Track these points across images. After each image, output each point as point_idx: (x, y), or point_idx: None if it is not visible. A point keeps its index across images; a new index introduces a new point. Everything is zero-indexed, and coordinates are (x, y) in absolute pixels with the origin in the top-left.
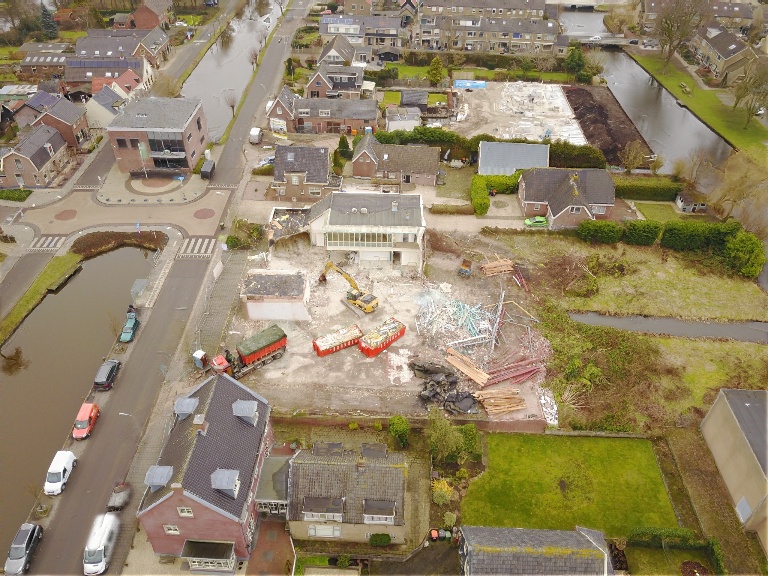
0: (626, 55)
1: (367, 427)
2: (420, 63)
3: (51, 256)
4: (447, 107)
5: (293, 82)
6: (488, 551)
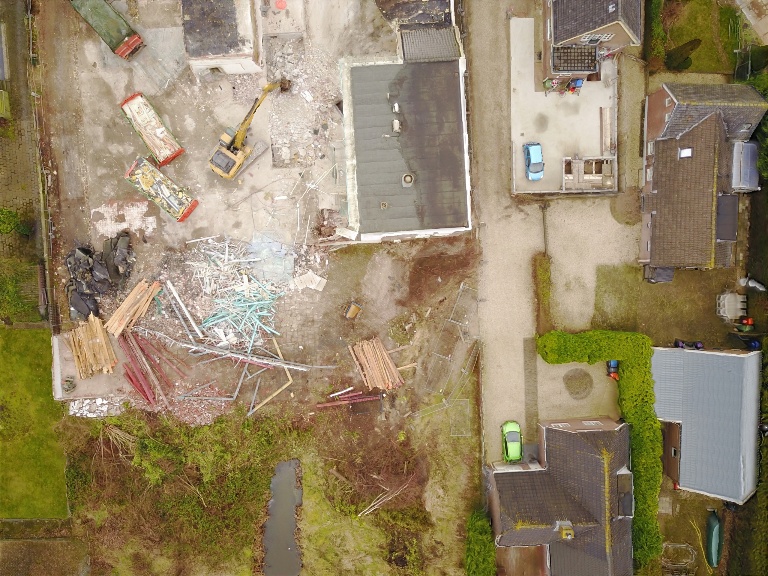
0: None
1: None
2: None
3: None
4: None
5: None
6: None
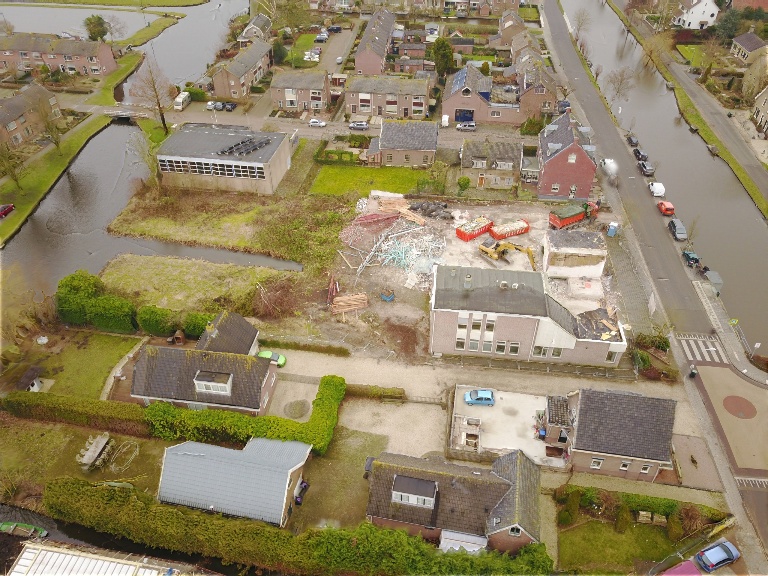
0: None
1: None
2: None
3: None
4: None
5: None
6: None
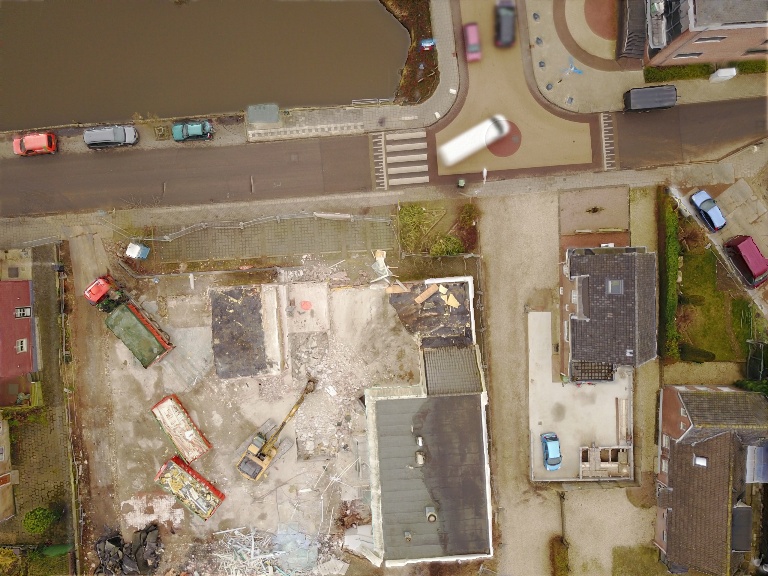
0: None
1: None
2: None
3: None
4: None
5: None
6: None
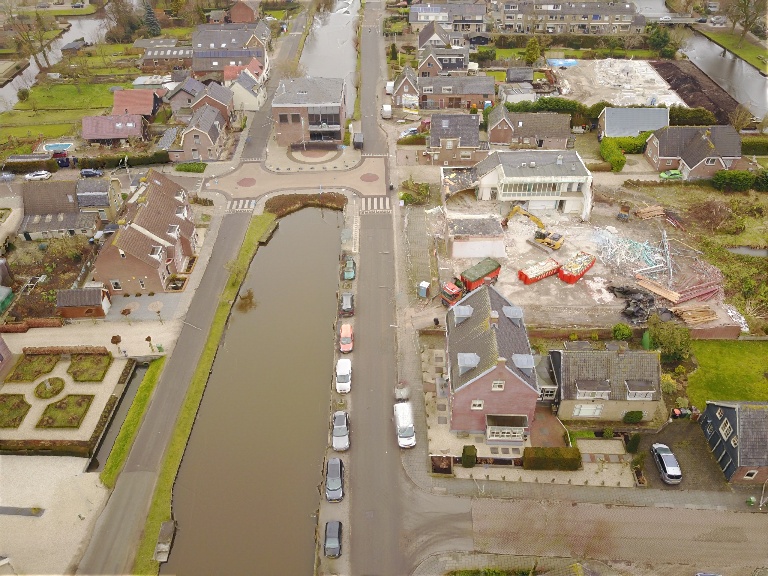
0: (696, 33)
1: (584, 338)
2: (508, 46)
3: (250, 215)
4: (548, 83)
5: (400, 66)
6: (753, 408)
